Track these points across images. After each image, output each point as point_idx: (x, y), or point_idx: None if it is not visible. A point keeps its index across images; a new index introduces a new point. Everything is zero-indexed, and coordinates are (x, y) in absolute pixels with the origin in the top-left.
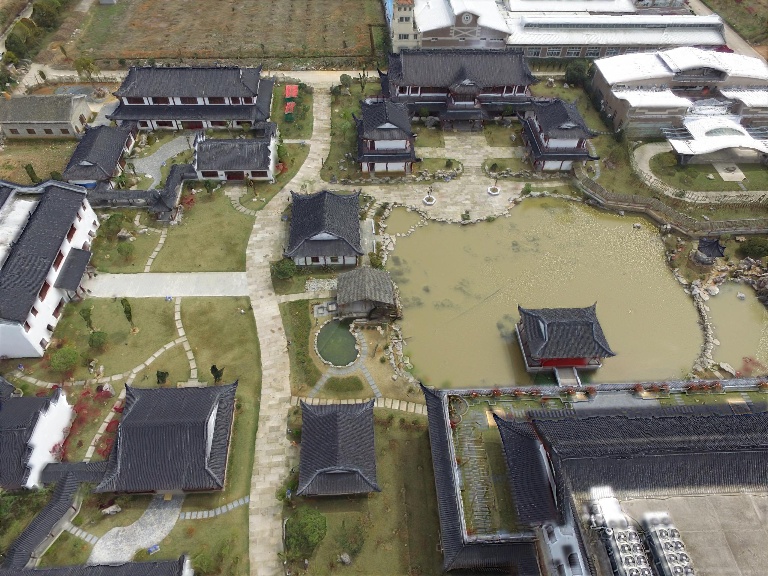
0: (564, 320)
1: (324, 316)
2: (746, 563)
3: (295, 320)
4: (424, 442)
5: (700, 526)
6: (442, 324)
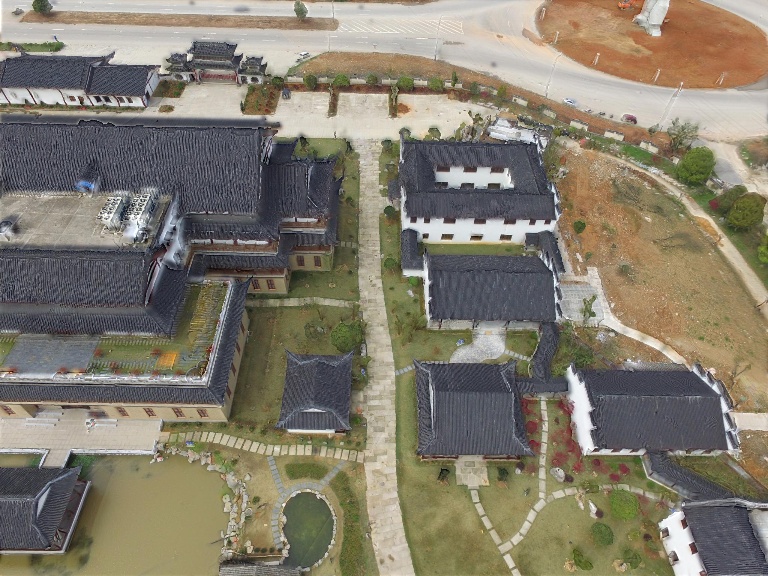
0: (6, 509)
1: (322, 575)
2: (64, 221)
3: (362, 574)
4: (237, 408)
5: (74, 237)
6: (162, 567)
